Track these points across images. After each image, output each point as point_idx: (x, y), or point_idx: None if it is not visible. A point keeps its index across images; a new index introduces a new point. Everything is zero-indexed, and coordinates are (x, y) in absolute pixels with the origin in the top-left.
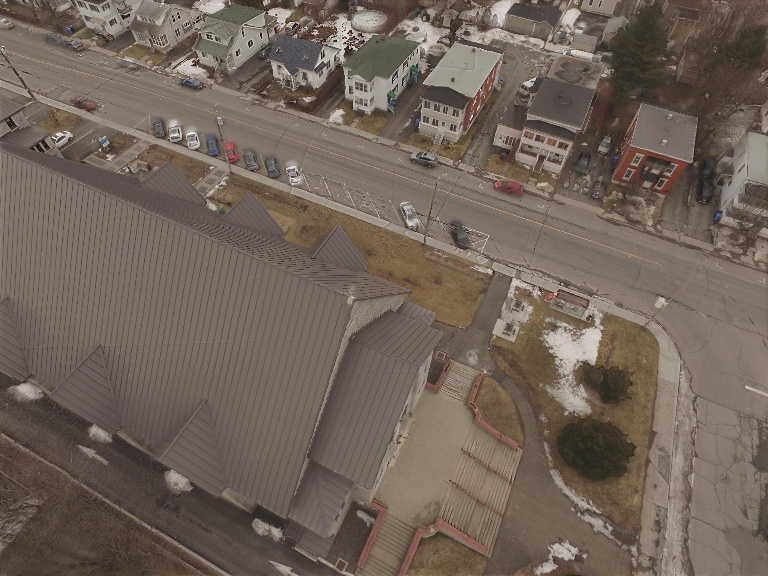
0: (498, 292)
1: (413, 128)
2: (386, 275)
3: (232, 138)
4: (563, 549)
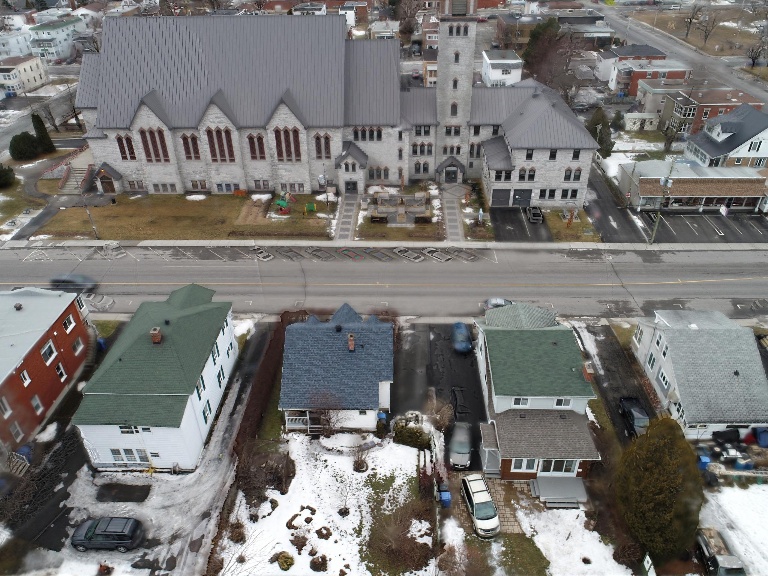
0: (29, 229)
1: (110, 343)
2: (135, 215)
3: (366, 267)
4: (28, 165)
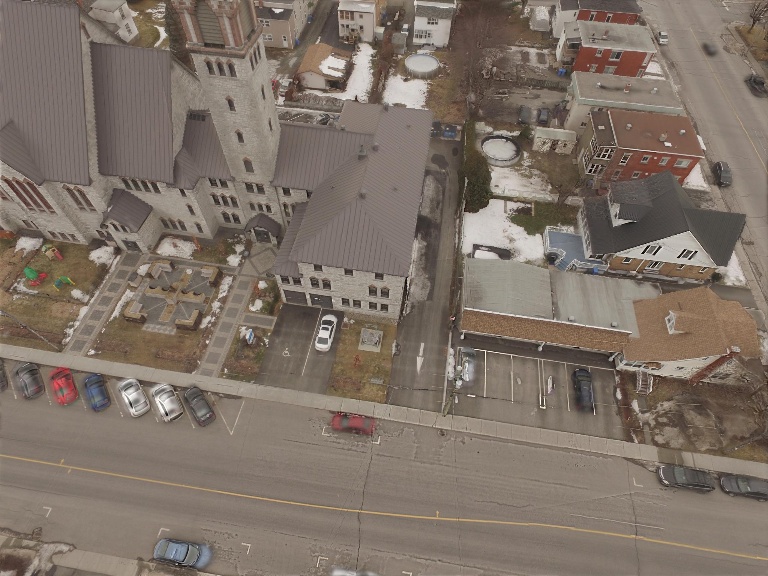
0: None
1: None
2: None
3: (68, 420)
4: None
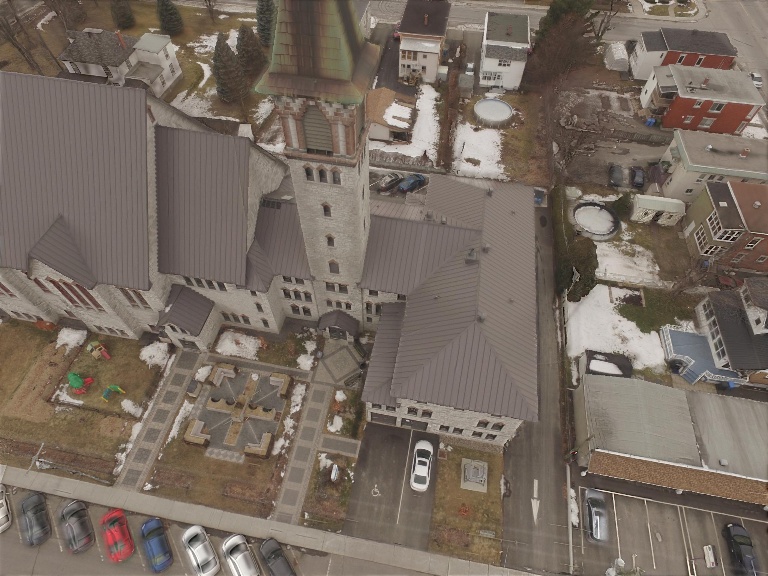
0: None
1: None
2: None
3: None
4: None
